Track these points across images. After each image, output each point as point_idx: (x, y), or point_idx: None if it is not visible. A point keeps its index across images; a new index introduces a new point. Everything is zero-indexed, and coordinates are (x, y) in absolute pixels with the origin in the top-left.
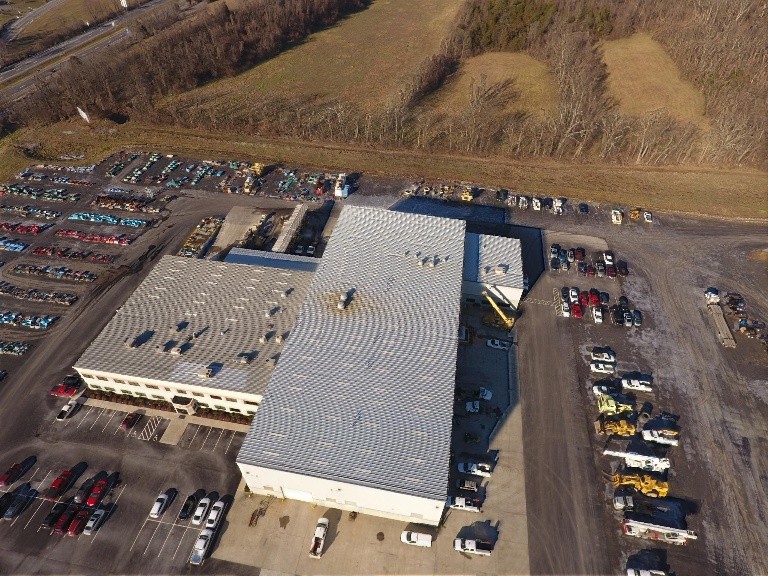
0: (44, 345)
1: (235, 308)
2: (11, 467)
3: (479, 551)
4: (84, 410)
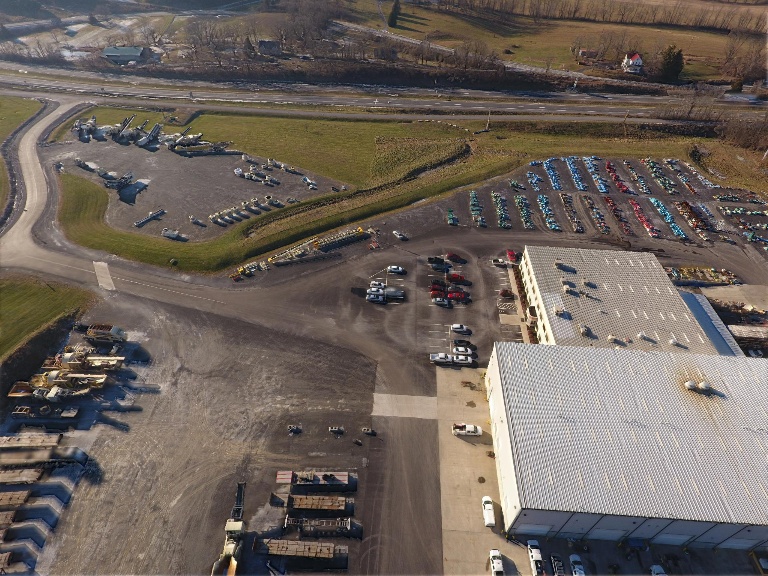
0: (538, 234)
1: (631, 312)
2: (458, 255)
3: (495, 574)
4: (504, 270)
